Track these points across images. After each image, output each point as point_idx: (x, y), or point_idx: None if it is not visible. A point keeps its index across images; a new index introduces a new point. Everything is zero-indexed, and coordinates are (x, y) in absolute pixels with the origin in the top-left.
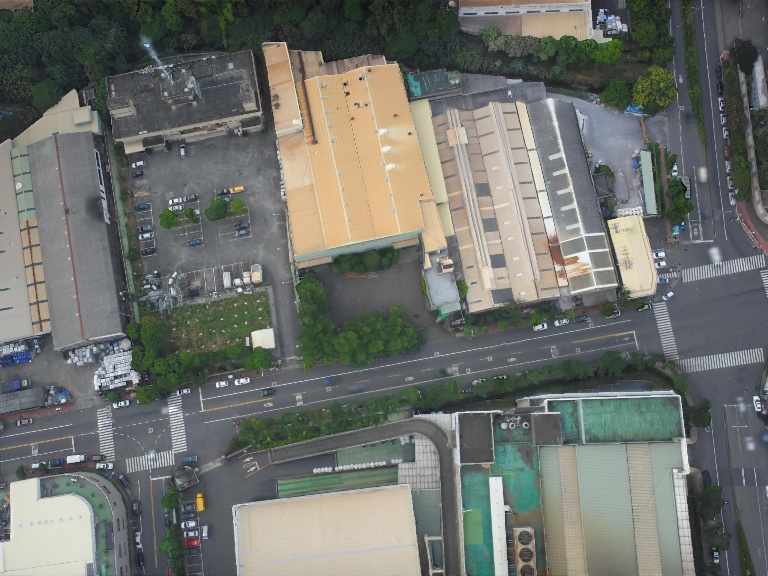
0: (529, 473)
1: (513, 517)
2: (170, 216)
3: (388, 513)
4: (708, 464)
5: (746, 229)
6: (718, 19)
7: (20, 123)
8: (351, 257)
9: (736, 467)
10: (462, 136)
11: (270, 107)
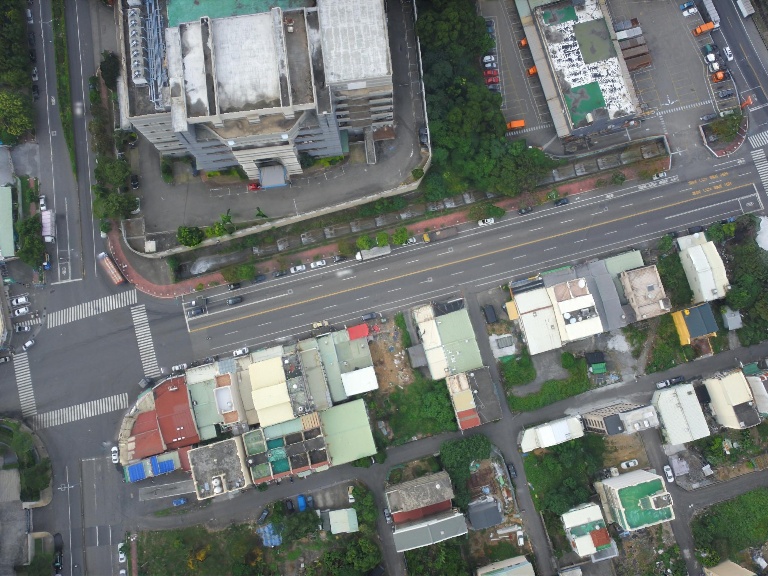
0: None
1: None
2: None
3: None
4: (61, 526)
5: (109, 264)
6: (94, 29)
7: None
8: None
9: (90, 526)
10: None
11: None
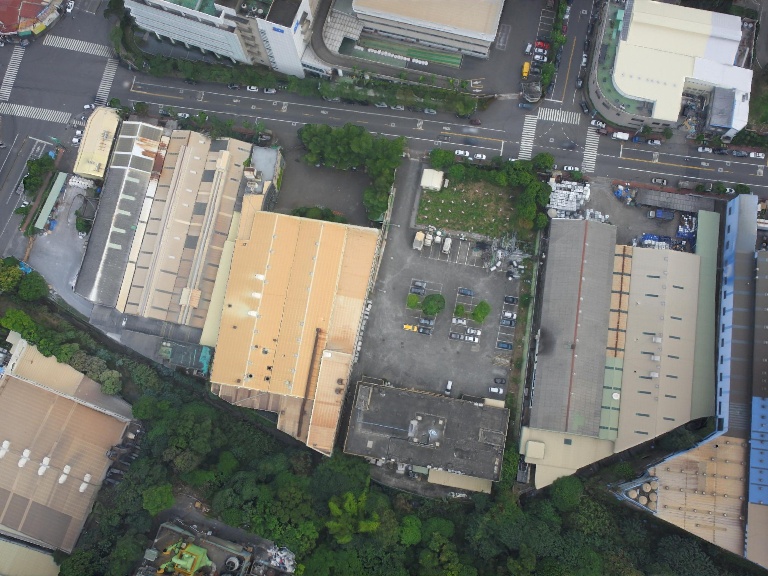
0: None
1: None
2: (478, 310)
3: None
4: None
5: None
6: None
7: (603, 477)
8: None
9: None
10: (186, 296)
11: (350, 399)
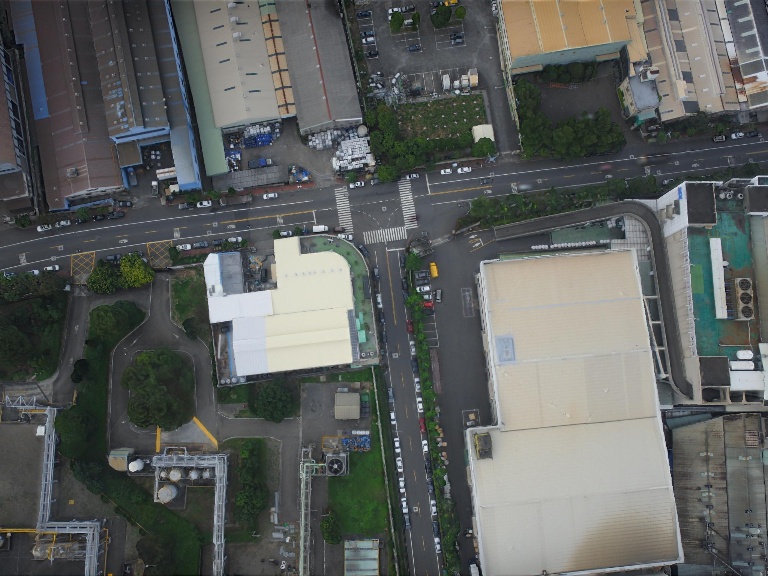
0: (742, 237)
1: (729, 272)
2: (401, 17)
3: (614, 272)
4: None
5: None
6: None
7: None
8: (557, 68)
9: None
10: None
11: None
